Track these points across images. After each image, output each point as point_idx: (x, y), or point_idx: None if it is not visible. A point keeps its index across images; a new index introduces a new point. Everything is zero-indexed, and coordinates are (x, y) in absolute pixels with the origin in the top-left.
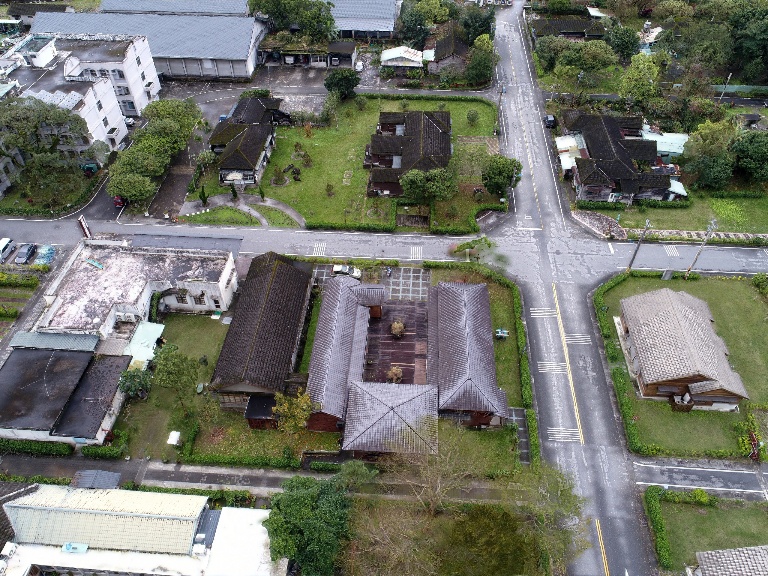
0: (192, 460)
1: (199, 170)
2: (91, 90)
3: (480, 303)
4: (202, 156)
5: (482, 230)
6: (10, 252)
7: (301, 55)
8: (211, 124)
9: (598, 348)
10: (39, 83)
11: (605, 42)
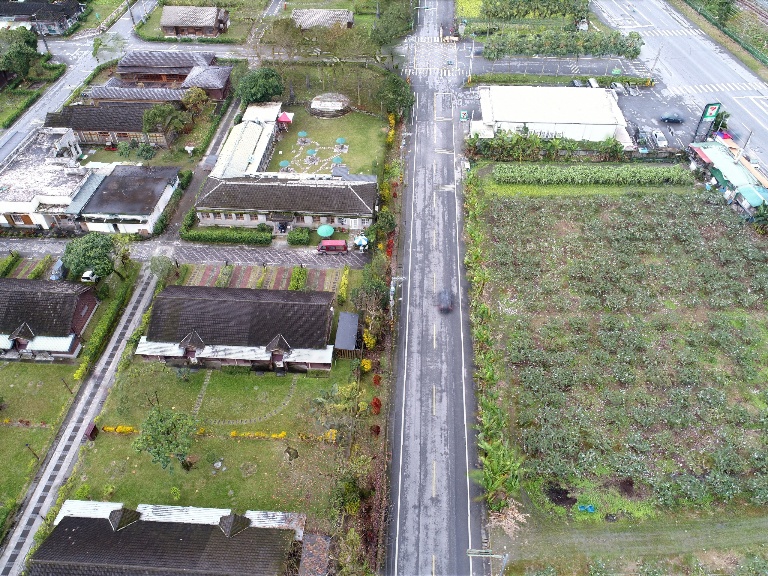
0: None
1: None
2: None
3: None
4: None
5: None
6: None
7: None
8: None
9: (182, 44)
10: None
11: None
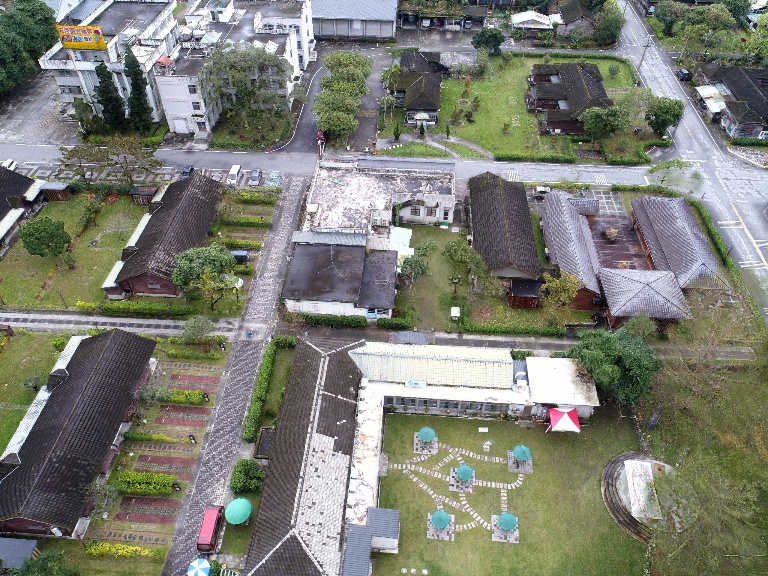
0: (473, 330)
1: (382, 112)
2: (288, 39)
3: (686, 211)
4: (391, 98)
5: (652, 162)
6: (240, 177)
7: (436, 19)
8: (373, 76)
9: None
10: (232, 35)
11: (723, 6)
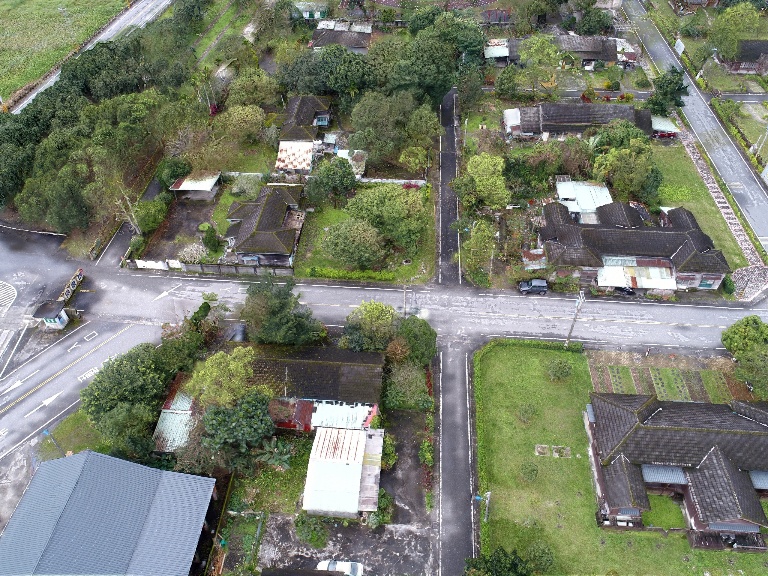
0: None
1: None
2: None
3: None
4: None
5: None
6: None
7: None
8: None
9: None
10: None
11: None
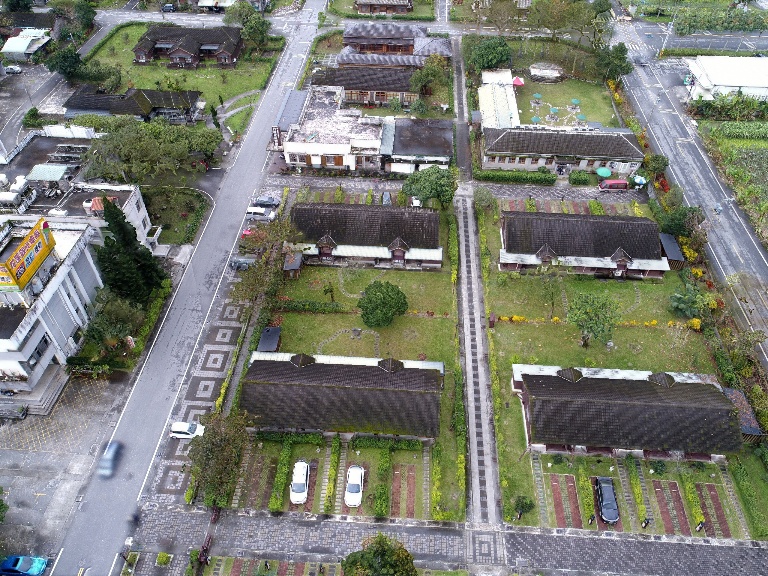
0: None
1: None
2: (72, 128)
3: None
4: None
5: None
6: None
7: None
8: None
9: (378, 20)
10: None
11: None
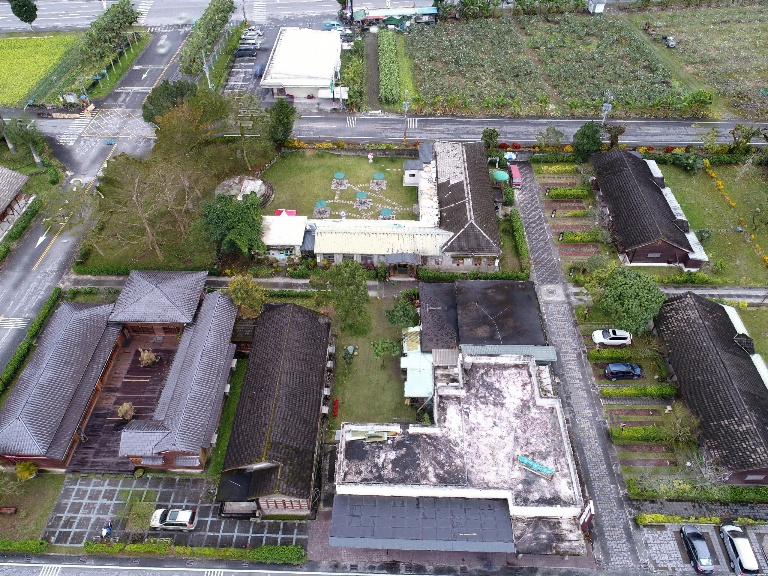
0: None
1: None
2: None
3: (8, 412)
4: None
5: None
6: None
7: None
8: None
9: None
10: None
11: None
